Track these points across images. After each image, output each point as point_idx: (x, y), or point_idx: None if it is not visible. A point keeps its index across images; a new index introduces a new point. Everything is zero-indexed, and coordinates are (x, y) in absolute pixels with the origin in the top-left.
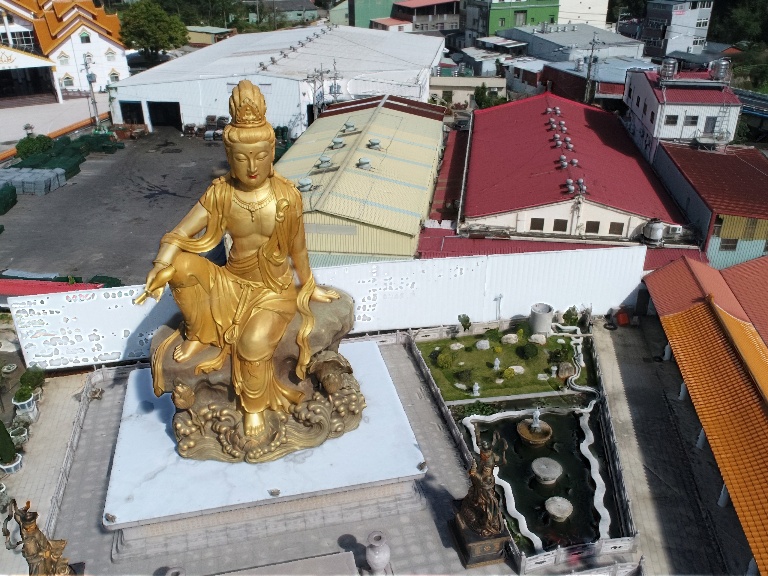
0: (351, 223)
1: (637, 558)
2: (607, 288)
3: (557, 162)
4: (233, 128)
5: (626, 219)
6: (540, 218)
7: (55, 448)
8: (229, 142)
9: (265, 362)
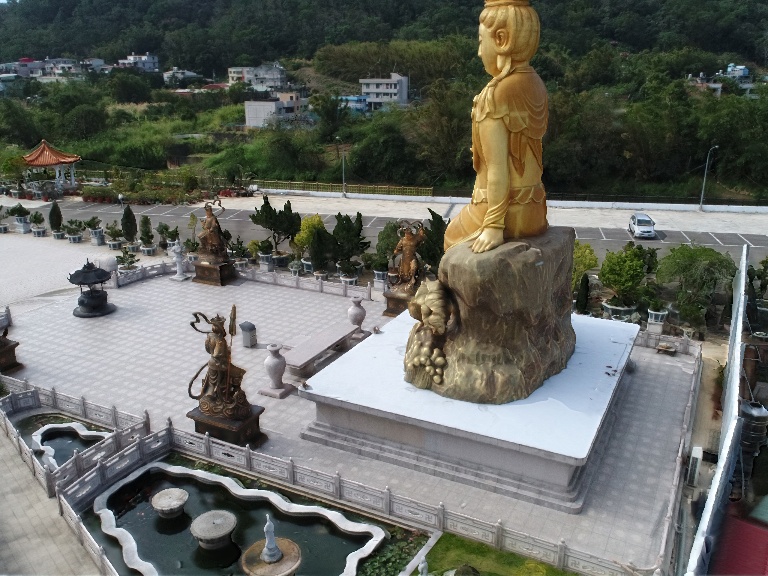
0: None
1: (58, 509)
2: None
3: None
4: None
5: None
6: None
7: None
8: None
9: None
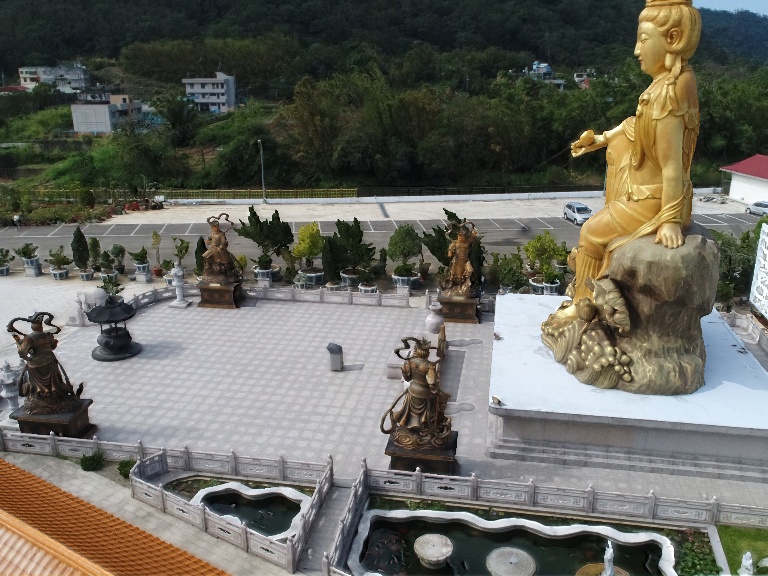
0: None
1: None
2: None
3: None
4: None
5: None
6: None
7: None
8: None
9: (586, 255)
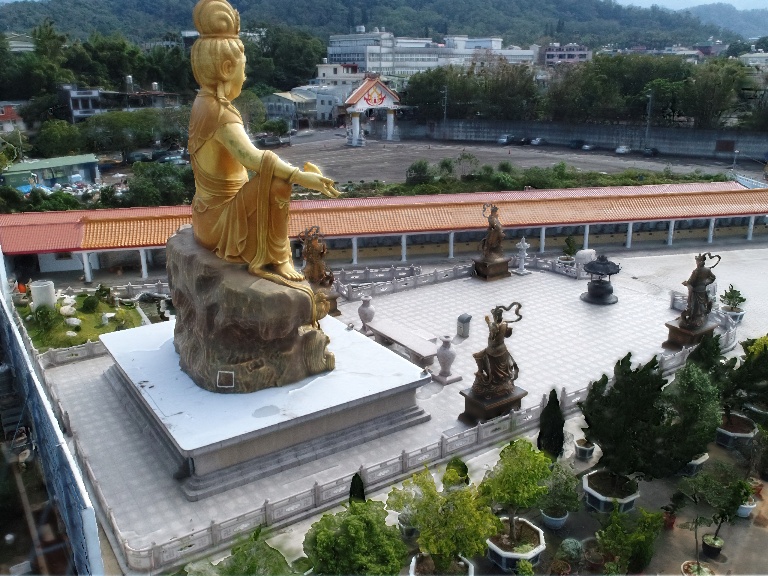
0: None
1: None
2: (3, 268)
3: None
4: None
5: None
6: None
7: None
8: None
9: None
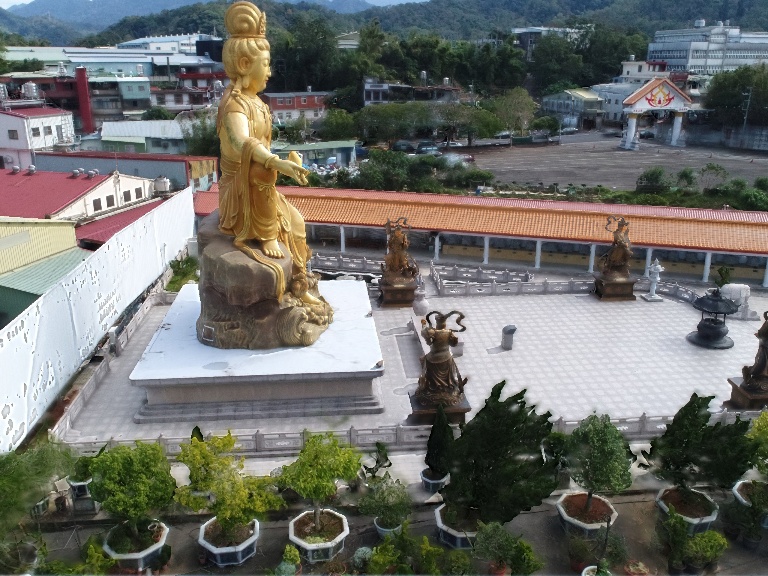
0: (24, 228)
1: None
2: (187, 224)
3: (14, 173)
4: (257, 39)
5: (142, 183)
6: (98, 198)
7: (180, 474)
8: (259, 50)
9: None
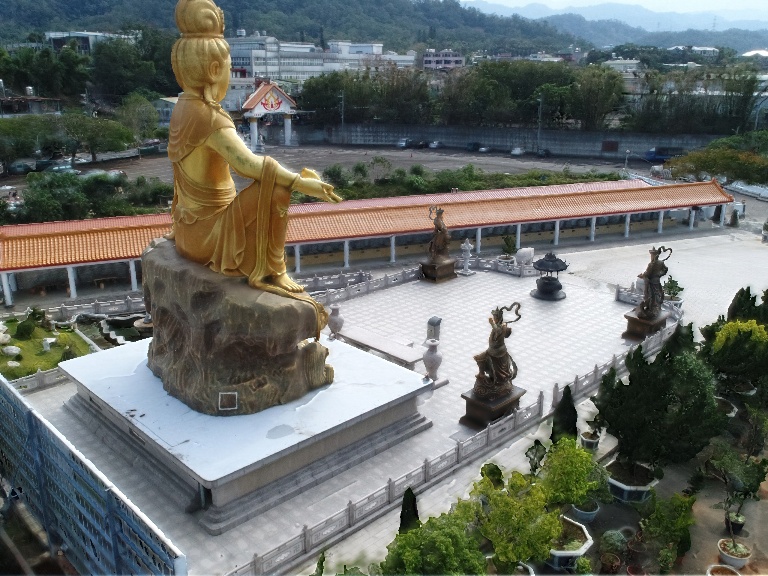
0: None
1: None
2: None
3: None
4: None
5: None
6: None
7: (348, 560)
8: None
9: None
